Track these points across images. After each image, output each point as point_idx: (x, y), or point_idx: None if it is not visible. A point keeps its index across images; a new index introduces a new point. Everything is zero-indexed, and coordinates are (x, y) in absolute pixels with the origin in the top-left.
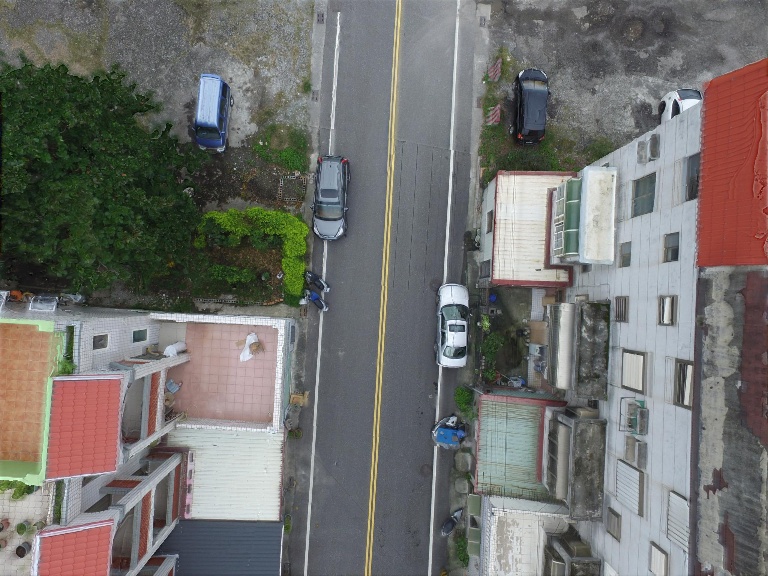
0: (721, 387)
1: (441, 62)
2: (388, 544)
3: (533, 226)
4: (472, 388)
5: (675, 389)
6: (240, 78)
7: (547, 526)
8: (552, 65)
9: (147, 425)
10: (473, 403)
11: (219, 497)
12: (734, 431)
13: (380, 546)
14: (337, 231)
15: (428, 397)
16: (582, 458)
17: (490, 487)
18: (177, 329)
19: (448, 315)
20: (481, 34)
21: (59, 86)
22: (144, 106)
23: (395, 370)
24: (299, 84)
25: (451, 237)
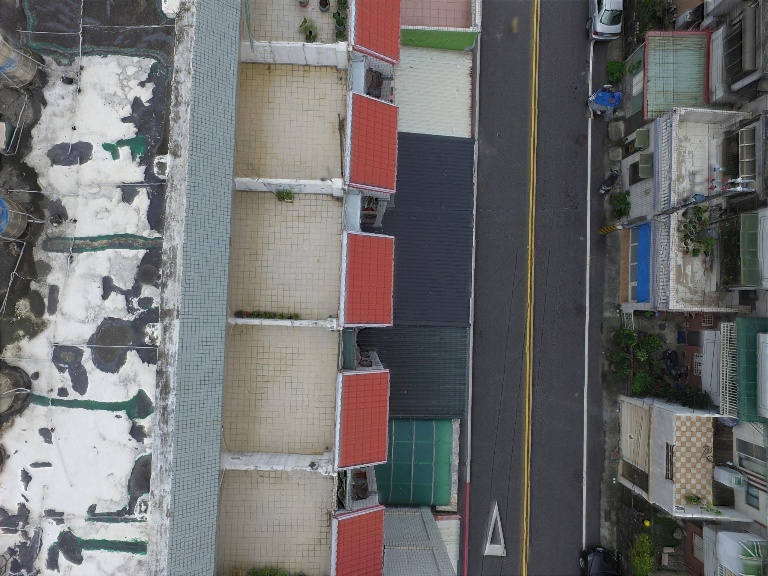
0: None
1: None
2: (549, 207)
3: None
4: (623, 61)
5: None
6: None
7: None
8: None
9: None
10: (626, 72)
11: (417, 114)
12: None
13: (542, 209)
14: None
15: (581, 74)
16: None
17: (660, 113)
18: None
19: None
20: None
21: None
22: None
23: (550, 49)
24: None
25: None
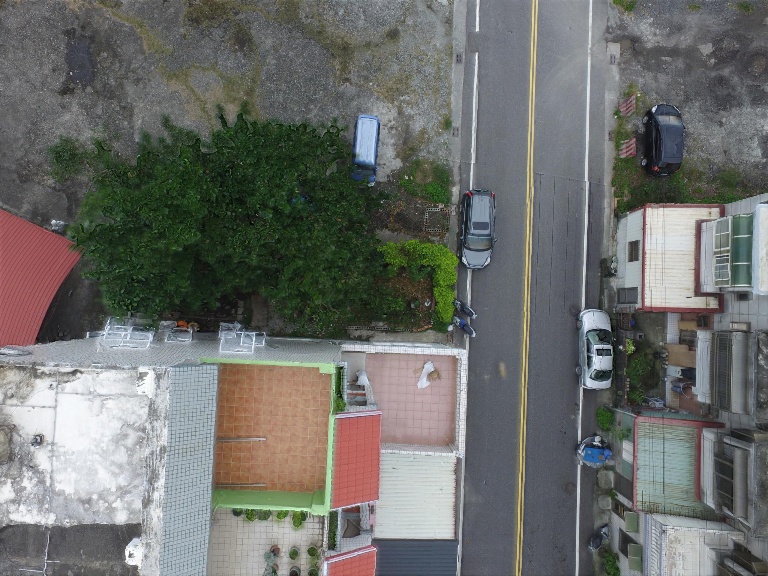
0: None
1: (575, 98)
2: (536, 559)
3: (683, 256)
4: (614, 409)
5: None
6: (385, 116)
7: (708, 542)
8: (680, 100)
9: None
10: (616, 423)
11: (399, 517)
12: None
13: (529, 561)
14: (485, 261)
15: (571, 417)
16: (763, 479)
17: (650, 505)
18: (357, 359)
19: (593, 340)
20: (612, 71)
21: (298, 143)
22: (345, 154)
23: (539, 392)
24: (441, 121)
25: (588, 264)
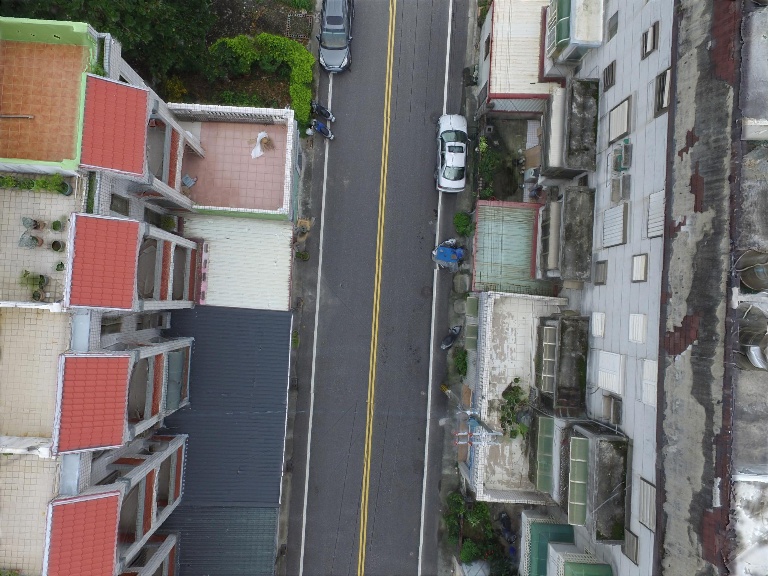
0: (694, 57)
1: None
2: (390, 360)
3: (528, 43)
4: (470, 213)
5: (655, 105)
6: None
7: None
8: None
9: (168, 175)
10: None
11: (232, 286)
12: (705, 88)
13: (383, 362)
14: (342, 61)
15: (428, 223)
16: (572, 224)
17: (487, 285)
18: (192, 128)
19: None
20: None
21: None
22: None
23: (397, 197)
24: None
25: (450, 73)
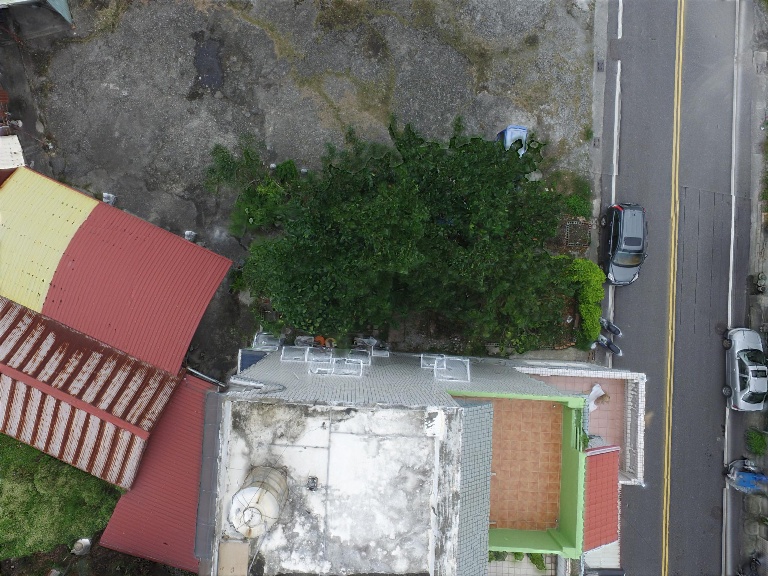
0: None
1: (720, 109)
2: None
3: None
4: (762, 431)
5: None
6: (524, 125)
7: None
8: None
9: None
10: (767, 446)
11: None
12: None
13: None
14: (633, 277)
15: (716, 439)
16: None
17: None
18: None
19: (745, 360)
20: (758, 81)
21: (512, 159)
22: None
23: (684, 413)
24: (581, 131)
25: (734, 281)
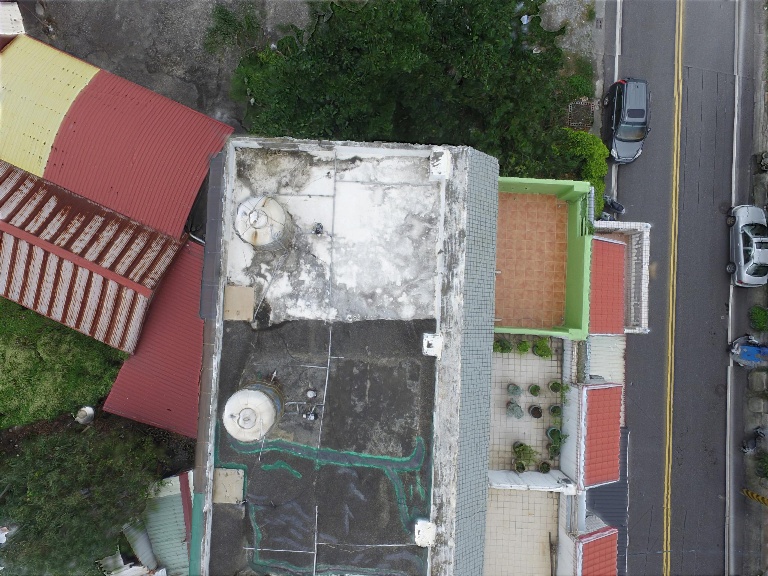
0: None
1: None
2: (686, 462)
3: None
4: (766, 308)
5: None
6: None
7: None
8: None
9: None
10: None
11: None
12: None
13: (678, 464)
14: (636, 153)
15: (720, 318)
16: None
17: None
18: None
19: None
20: None
21: None
22: None
23: (687, 291)
24: (584, 12)
25: (738, 161)
